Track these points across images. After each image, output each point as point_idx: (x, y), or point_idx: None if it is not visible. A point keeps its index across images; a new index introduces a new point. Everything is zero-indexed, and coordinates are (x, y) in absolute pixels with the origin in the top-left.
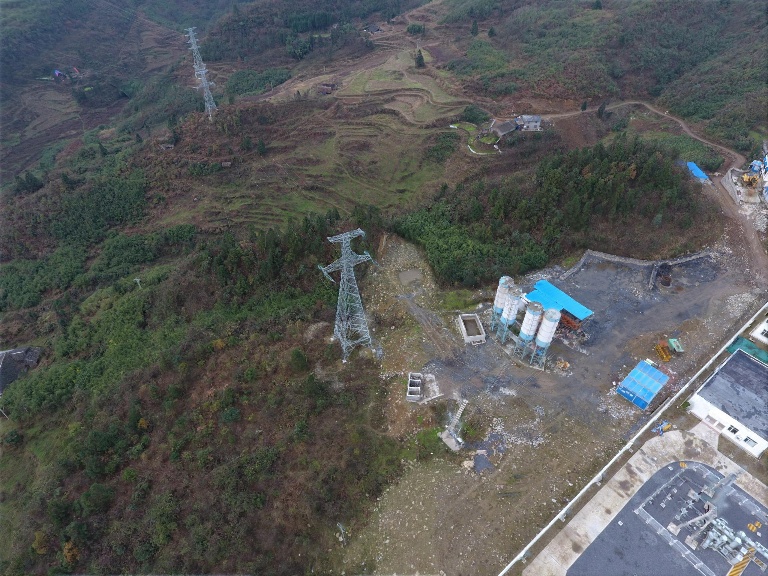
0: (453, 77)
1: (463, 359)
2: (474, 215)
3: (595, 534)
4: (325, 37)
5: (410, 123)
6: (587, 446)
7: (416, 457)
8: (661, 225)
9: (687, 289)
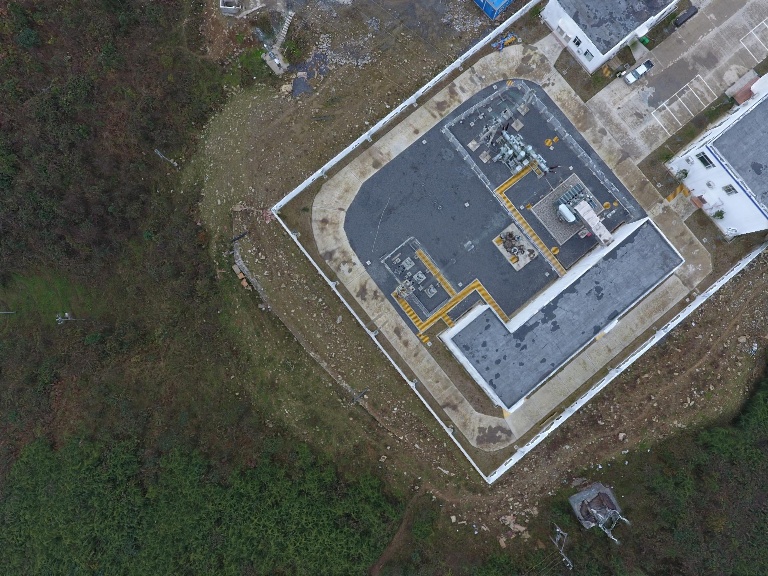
0: None
1: None
2: None
3: (397, 152)
4: None
5: None
6: (416, 65)
7: (239, 82)
8: None
9: None
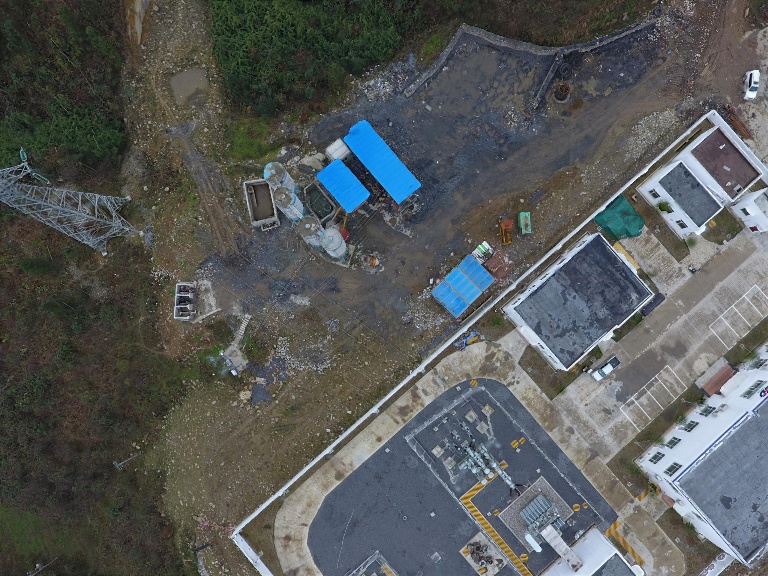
0: None
1: (248, 254)
2: None
3: (360, 462)
4: None
5: None
6: (377, 367)
7: (198, 377)
8: None
9: (588, 105)
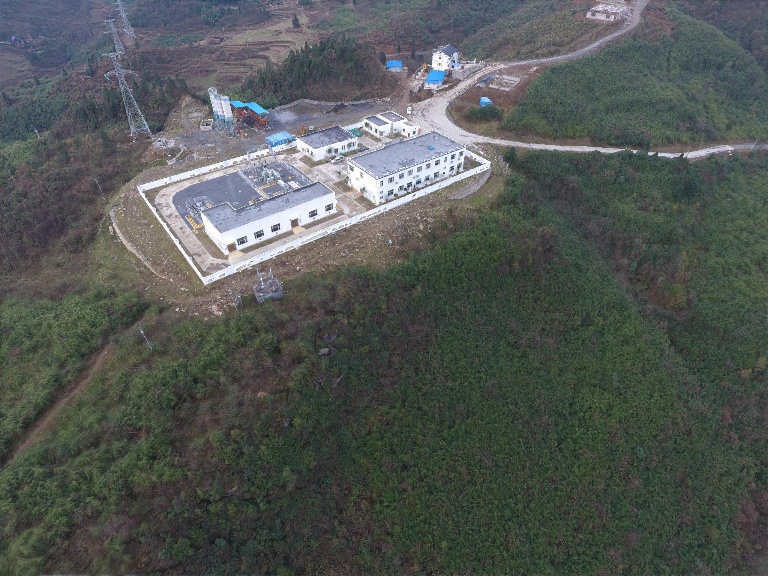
0: (316, 33)
1: None
2: (248, 87)
3: (212, 178)
4: (234, 9)
5: (274, 63)
6: None
7: None
8: (344, 83)
9: (346, 113)
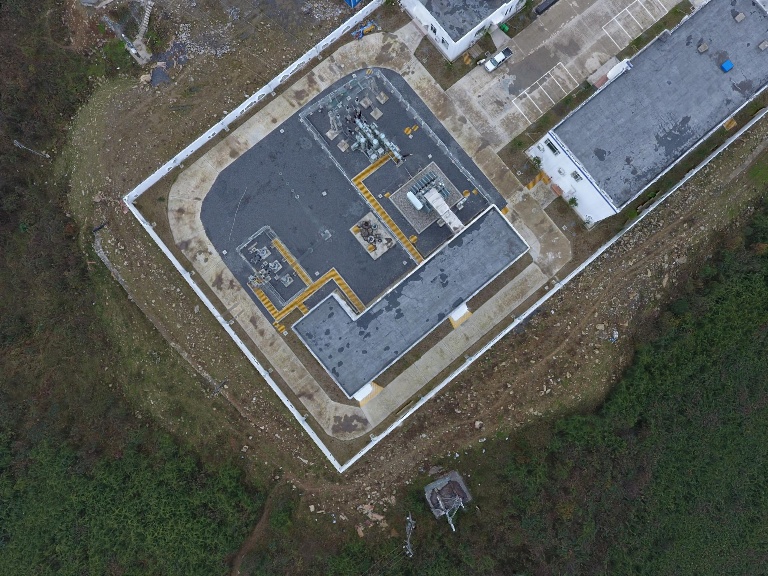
0: None
1: None
2: None
3: (255, 141)
4: None
5: None
6: (275, 54)
7: (105, 73)
8: None
9: None
